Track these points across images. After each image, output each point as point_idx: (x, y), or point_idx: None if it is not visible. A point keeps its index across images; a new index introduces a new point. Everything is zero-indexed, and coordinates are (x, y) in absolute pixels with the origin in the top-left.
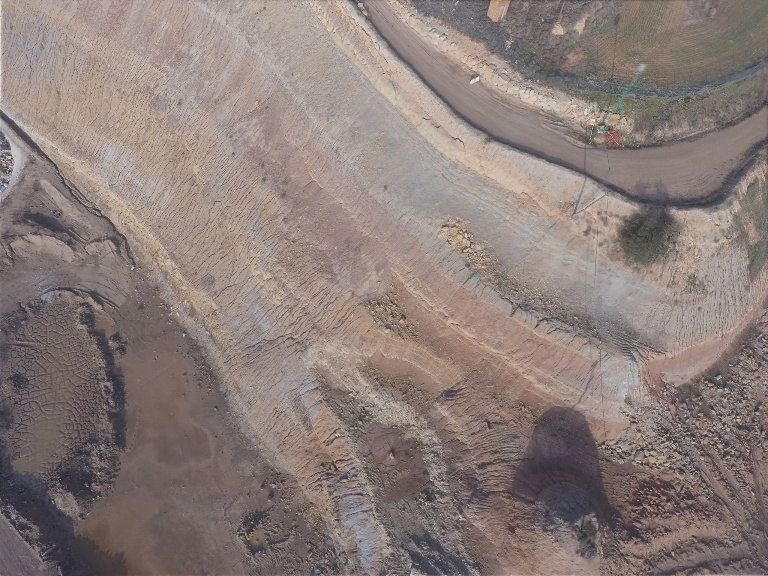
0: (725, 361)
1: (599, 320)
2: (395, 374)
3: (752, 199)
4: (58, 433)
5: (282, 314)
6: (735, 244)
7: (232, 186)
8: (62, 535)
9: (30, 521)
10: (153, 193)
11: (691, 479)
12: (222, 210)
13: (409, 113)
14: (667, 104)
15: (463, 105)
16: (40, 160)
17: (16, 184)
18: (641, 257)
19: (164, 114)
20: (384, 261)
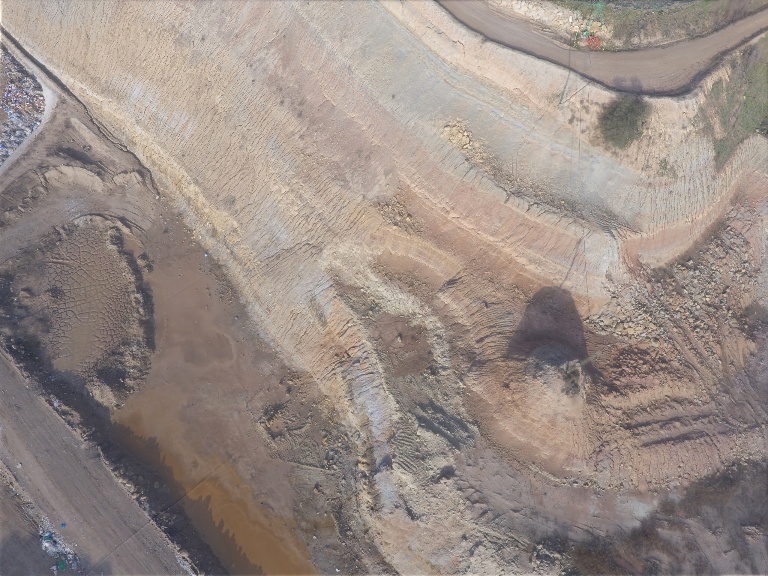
0: (696, 249)
1: (583, 204)
2: (402, 270)
3: (717, 97)
4: (93, 337)
5: (299, 223)
6: (701, 134)
7: (252, 110)
8: (100, 422)
9: (71, 408)
10: (177, 125)
11: (665, 347)
12: (243, 133)
13: (415, 25)
14: (642, 15)
15: (463, 14)
16: (70, 100)
17: (48, 121)
18: (618, 142)
19: (188, 50)
20: (392, 166)
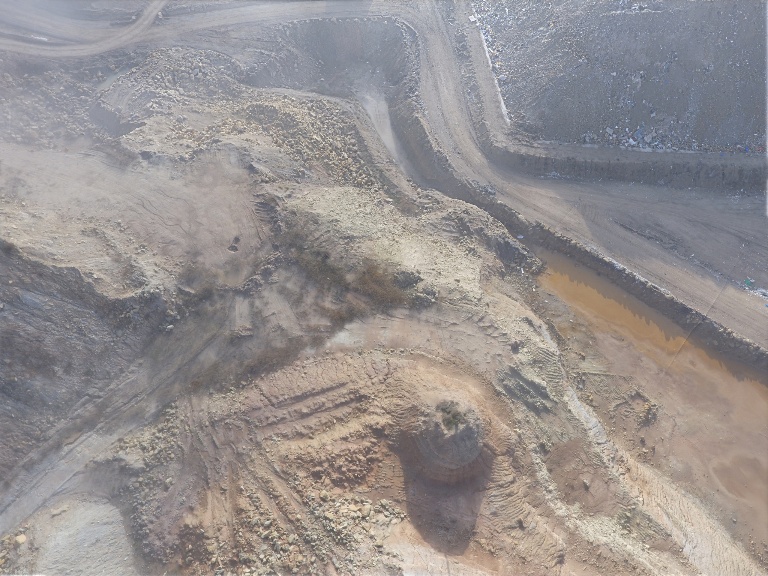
0: None
1: None
2: None
3: None
4: None
5: None
6: None
7: None
8: None
9: None
10: None
11: (313, 492)
12: None
13: None
14: None
15: None
16: None
17: None
18: None
19: None
20: None
